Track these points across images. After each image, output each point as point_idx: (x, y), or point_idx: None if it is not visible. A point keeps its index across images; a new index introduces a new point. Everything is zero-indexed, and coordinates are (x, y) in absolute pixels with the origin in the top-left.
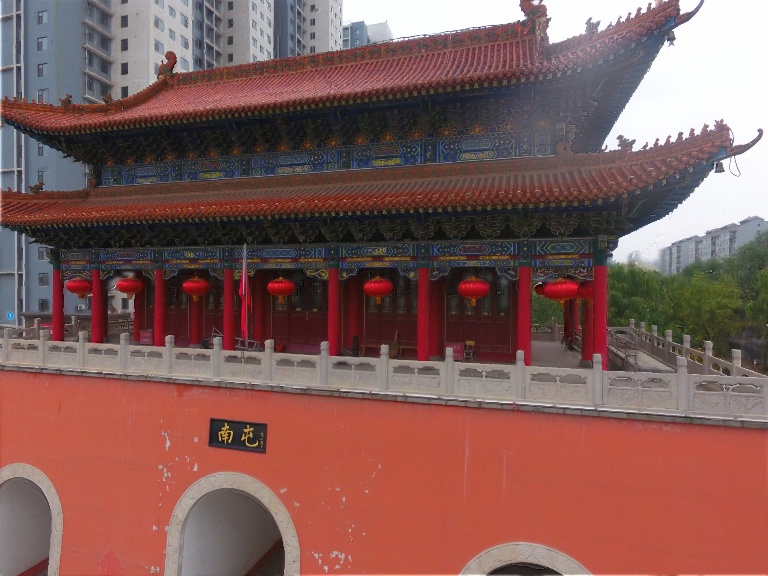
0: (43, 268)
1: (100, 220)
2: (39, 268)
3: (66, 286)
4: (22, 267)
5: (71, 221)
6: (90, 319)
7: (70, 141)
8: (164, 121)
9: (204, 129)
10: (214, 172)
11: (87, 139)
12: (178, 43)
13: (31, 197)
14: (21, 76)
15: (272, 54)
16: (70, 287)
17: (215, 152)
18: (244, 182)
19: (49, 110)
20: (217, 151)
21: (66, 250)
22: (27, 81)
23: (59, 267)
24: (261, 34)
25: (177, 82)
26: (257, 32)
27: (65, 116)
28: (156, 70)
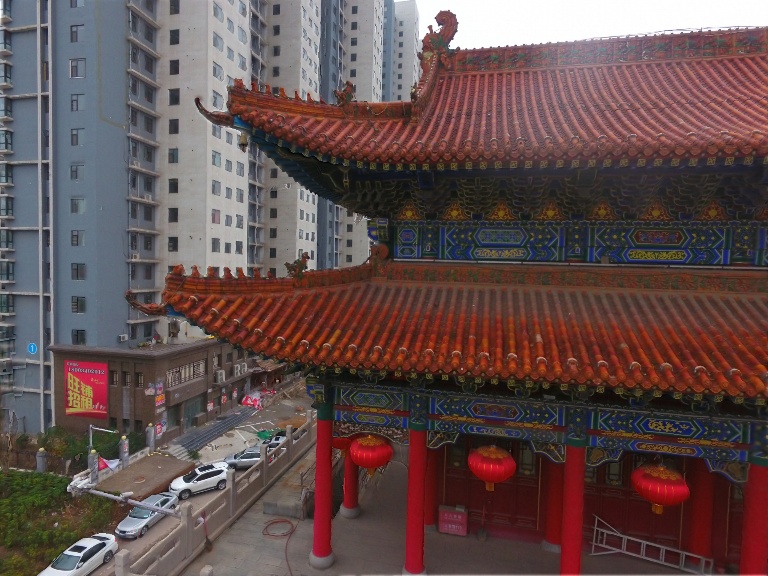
0: (78, 290)
1: (550, 379)
2: (72, 290)
3: (354, 457)
4: (49, 288)
5: (464, 372)
6: (146, 359)
7: (355, 174)
8: (671, 158)
9: (685, 170)
10: (665, 250)
11: (390, 172)
12: (236, 8)
13: (290, 285)
14: (48, 40)
15: (319, 28)
16: (365, 461)
17: (663, 210)
18: (757, 278)
19: (320, 112)
20: (670, 209)
21: (351, 386)
22: (55, 47)
23: (331, 415)
24: (310, 4)
25: (460, 65)
26: (307, 1)
27: (350, 125)
28: (215, 41)
